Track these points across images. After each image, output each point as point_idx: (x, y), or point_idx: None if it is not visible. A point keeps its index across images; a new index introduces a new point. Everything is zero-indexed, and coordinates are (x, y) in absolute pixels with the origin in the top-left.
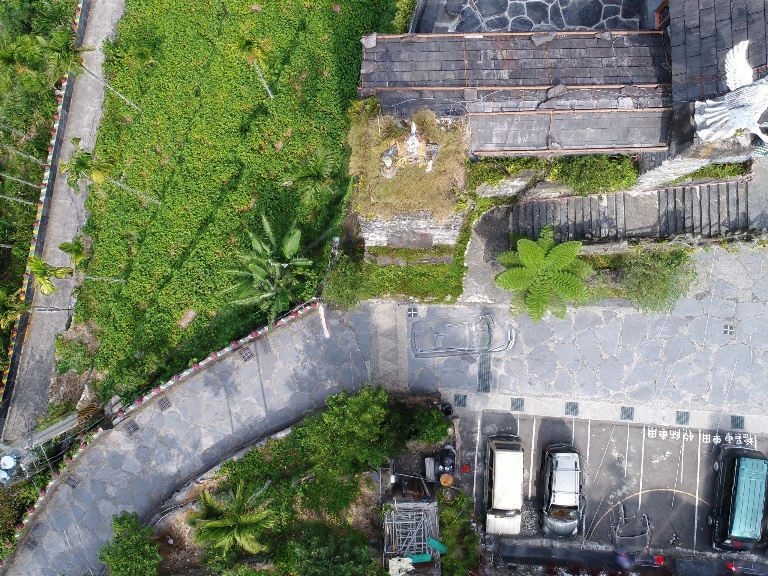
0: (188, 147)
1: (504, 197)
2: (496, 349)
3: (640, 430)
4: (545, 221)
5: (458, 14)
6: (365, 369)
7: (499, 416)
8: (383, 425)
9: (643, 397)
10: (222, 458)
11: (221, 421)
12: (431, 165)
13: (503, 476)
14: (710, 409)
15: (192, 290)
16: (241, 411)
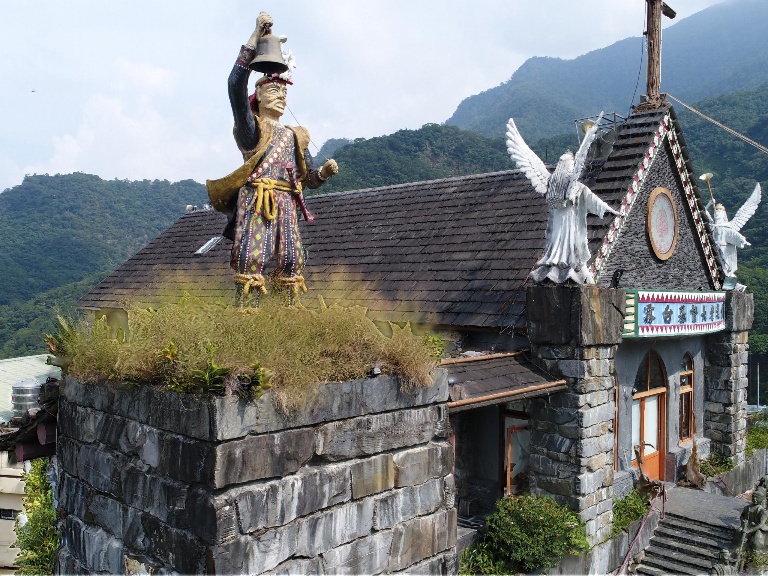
0: None
1: None
2: None
3: None
4: None
5: None
6: None
7: None
8: None
9: None
10: None
11: None
12: None
13: None
14: None
15: None
16: None
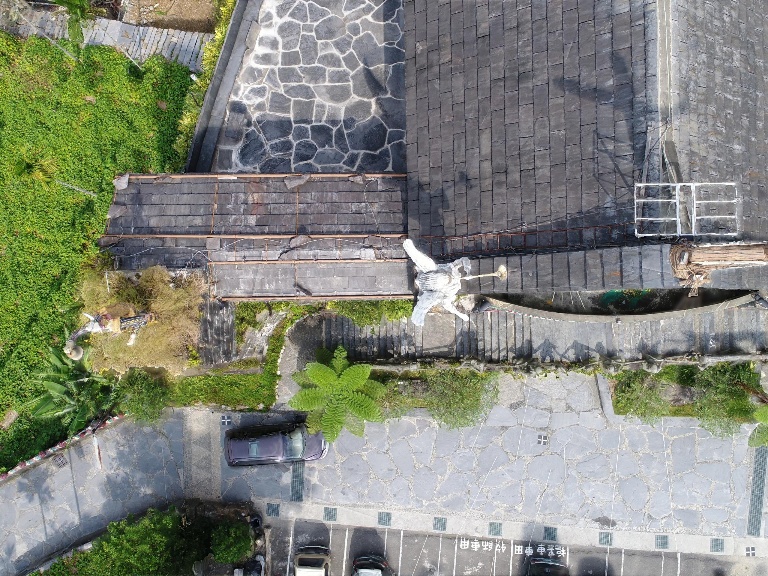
0: (19, 241)
1: (317, 305)
2: (309, 458)
3: (452, 541)
4: (353, 333)
5: (242, 137)
6: (178, 477)
7: (312, 526)
8: (163, 553)
9: (456, 507)
10: (30, 569)
11: (35, 528)
12: (134, 338)
13: None
14: (523, 520)
15: (14, 391)
16: (55, 518)
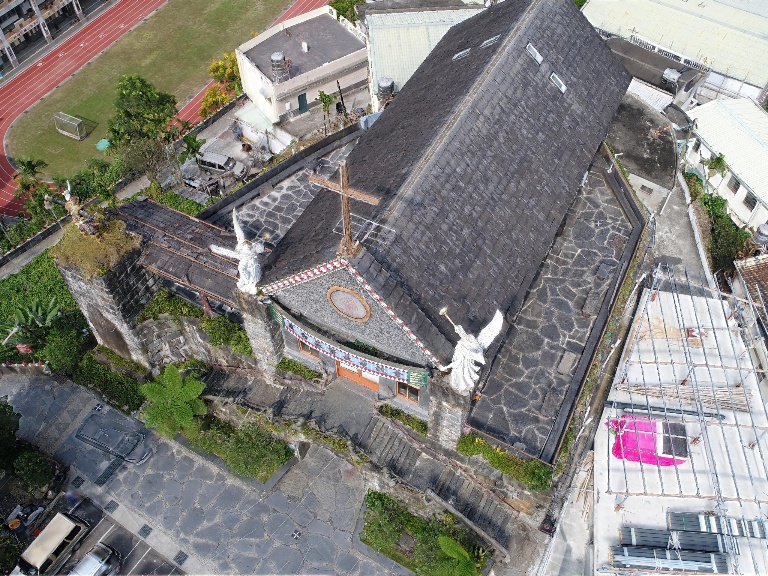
0: None
1: (208, 365)
2: (130, 460)
3: None
4: (216, 385)
5: None
6: (39, 427)
7: (93, 508)
8: None
9: (201, 552)
10: None
11: None
12: (81, 223)
13: (47, 533)
14: None
15: None
16: None
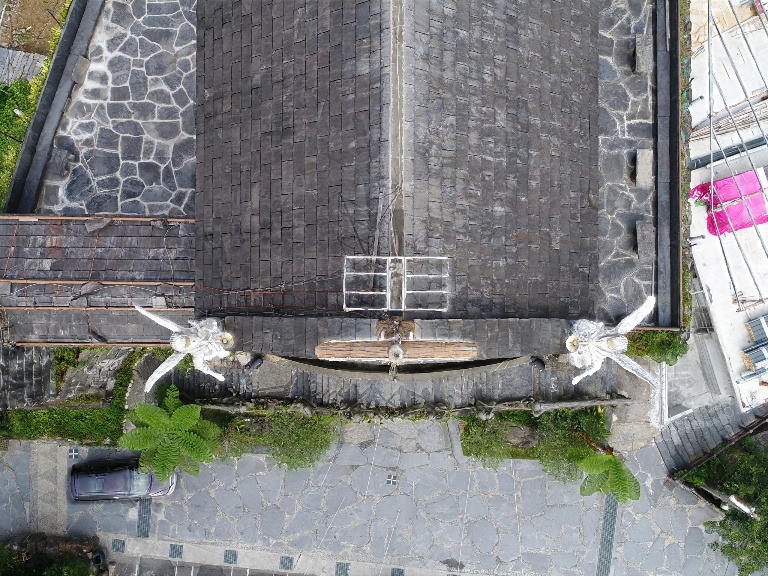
0: None
1: None
2: (156, 494)
3: None
4: None
5: (69, 173)
6: (24, 511)
7: (157, 562)
8: None
9: (303, 547)
10: None
11: None
12: None
13: None
14: (370, 561)
15: None
16: None
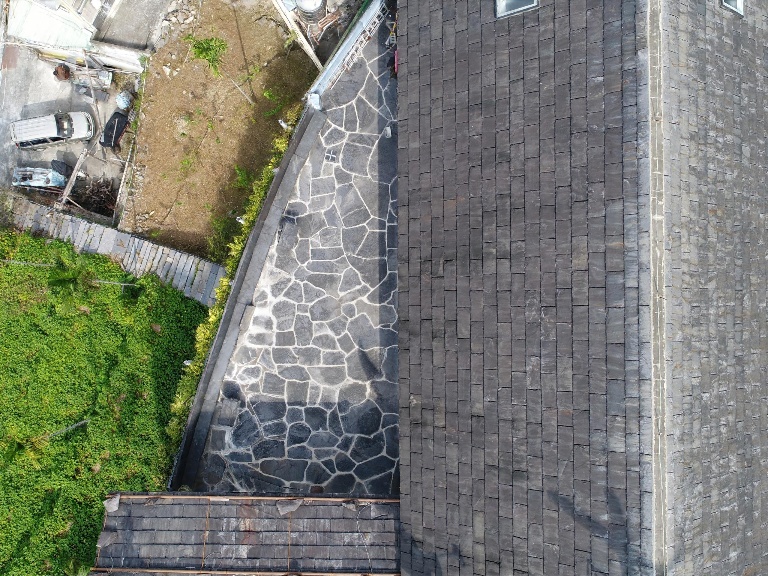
0: None
1: None
2: None
3: None
4: None
5: (235, 418)
6: None
7: None
8: None
9: None
10: None
11: None
12: None
13: None
14: None
15: None
16: None
